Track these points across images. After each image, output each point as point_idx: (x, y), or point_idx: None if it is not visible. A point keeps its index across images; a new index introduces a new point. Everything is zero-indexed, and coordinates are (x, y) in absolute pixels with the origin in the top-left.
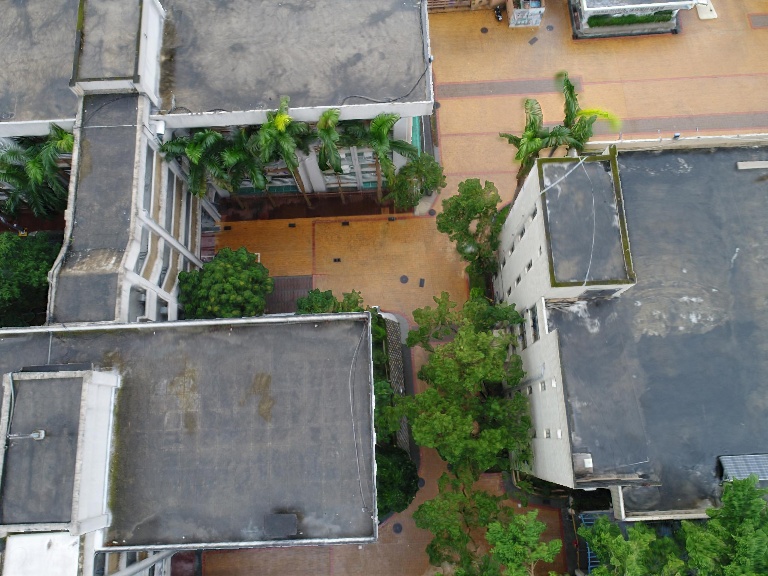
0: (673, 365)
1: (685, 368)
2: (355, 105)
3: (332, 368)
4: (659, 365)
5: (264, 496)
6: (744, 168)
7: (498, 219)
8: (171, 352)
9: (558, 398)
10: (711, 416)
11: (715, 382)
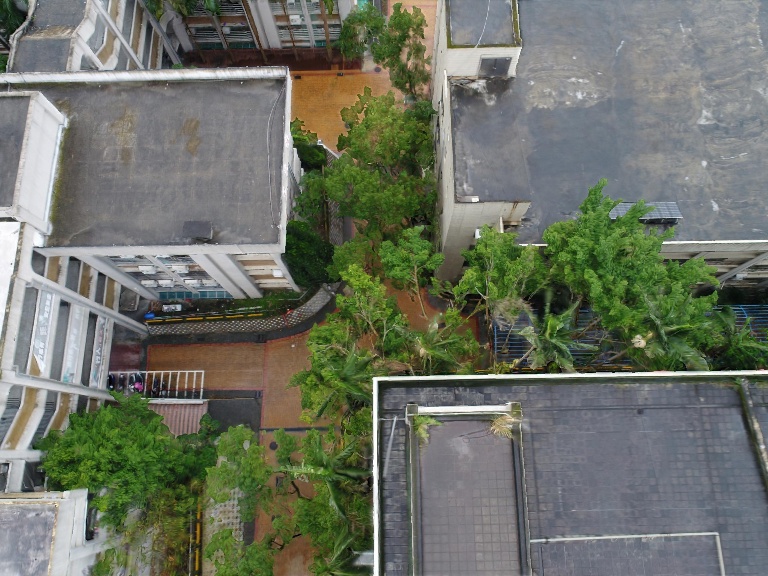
0: (558, 132)
1: (569, 135)
2: None
3: (253, 116)
4: (546, 132)
5: (186, 214)
6: None
7: None
8: (113, 101)
9: (449, 142)
10: (589, 173)
11: (595, 146)
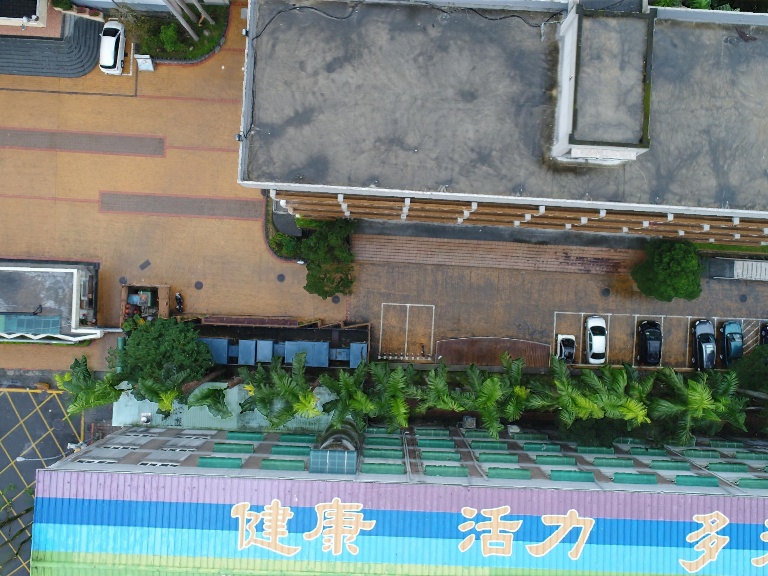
0: None
1: None
2: None
3: None
4: None
5: None
6: None
7: (216, 41)
8: None
9: None
10: None
11: None
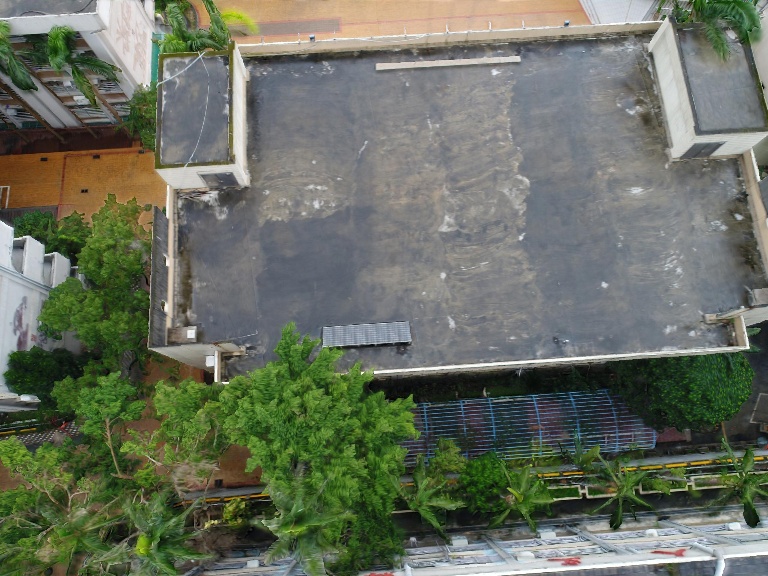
0: (292, 247)
1: (303, 249)
2: (22, 17)
3: None
4: (278, 247)
5: None
6: (381, 69)
7: None
8: None
9: None
10: (321, 292)
11: (329, 261)
